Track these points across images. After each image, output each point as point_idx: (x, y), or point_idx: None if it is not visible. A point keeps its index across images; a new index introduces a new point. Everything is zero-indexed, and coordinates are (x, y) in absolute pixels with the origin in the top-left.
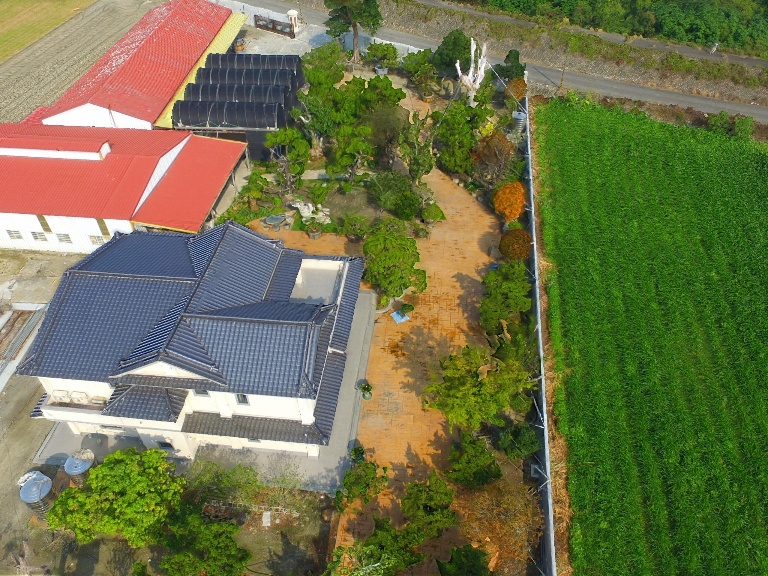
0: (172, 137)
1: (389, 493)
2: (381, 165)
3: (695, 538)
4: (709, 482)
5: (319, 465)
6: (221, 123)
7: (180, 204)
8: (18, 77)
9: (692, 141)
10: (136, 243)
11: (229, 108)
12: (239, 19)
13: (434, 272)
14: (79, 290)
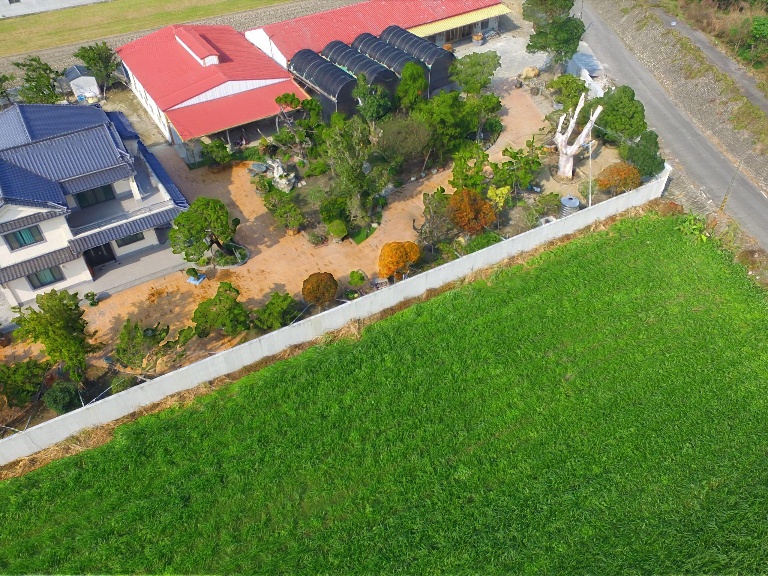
0: (272, 73)
1: (0, 359)
2: (401, 177)
3: (19, 574)
4: (103, 567)
5: (9, 313)
6: (311, 78)
7: (205, 118)
8: (326, 6)
9: (762, 357)
10: (85, 113)
11: (322, 68)
12: (497, 11)
13: (272, 271)
14: (6, 116)
